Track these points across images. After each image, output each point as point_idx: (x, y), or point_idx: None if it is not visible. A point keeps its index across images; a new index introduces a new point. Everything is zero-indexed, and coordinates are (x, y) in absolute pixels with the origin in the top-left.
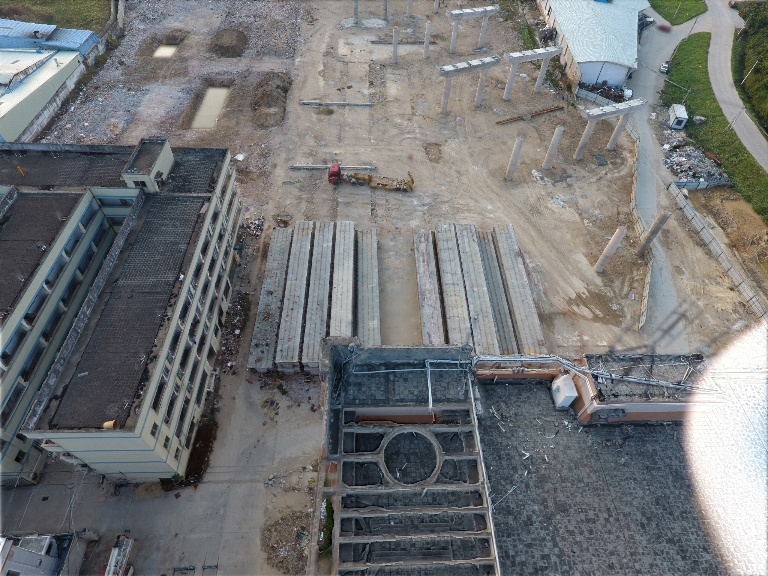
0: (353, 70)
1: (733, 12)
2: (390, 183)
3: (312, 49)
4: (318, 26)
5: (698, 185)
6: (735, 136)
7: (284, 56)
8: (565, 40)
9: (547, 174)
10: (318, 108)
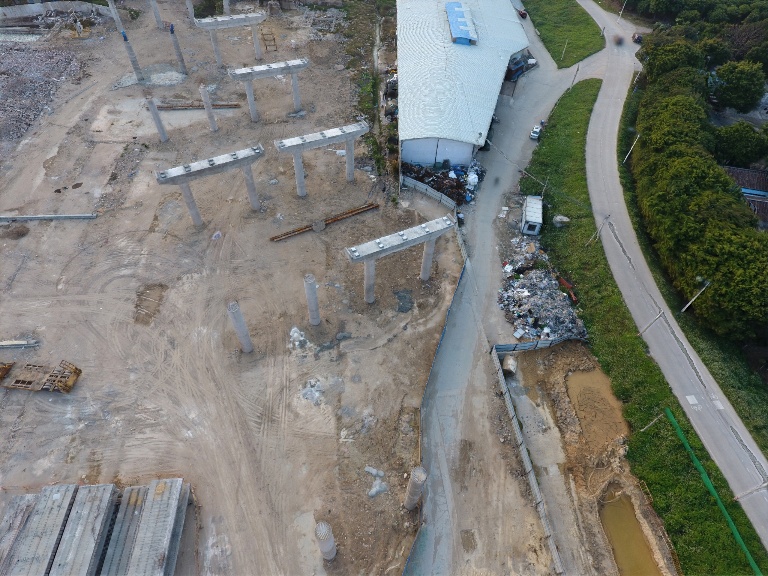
0: (97, 156)
1: (636, 49)
2: (38, 378)
3: (56, 123)
4: (85, 85)
5: (536, 344)
6: (601, 254)
7: (6, 137)
8: (398, 103)
9: (313, 335)
10: (7, 227)
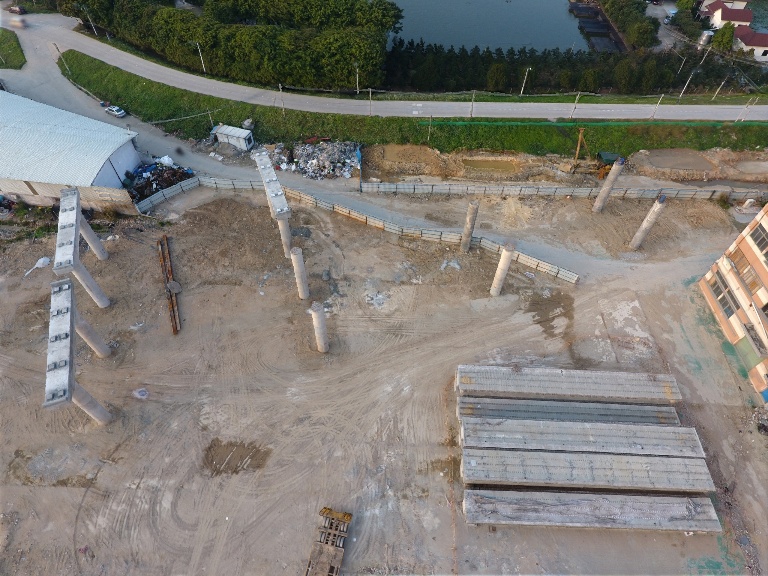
0: None
1: (34, 17)
2: (327, 560)
3: None
4: None
5: None
6: (296, 111)
7: None
8: (7, 180)
9: (320, 297)
10: None
